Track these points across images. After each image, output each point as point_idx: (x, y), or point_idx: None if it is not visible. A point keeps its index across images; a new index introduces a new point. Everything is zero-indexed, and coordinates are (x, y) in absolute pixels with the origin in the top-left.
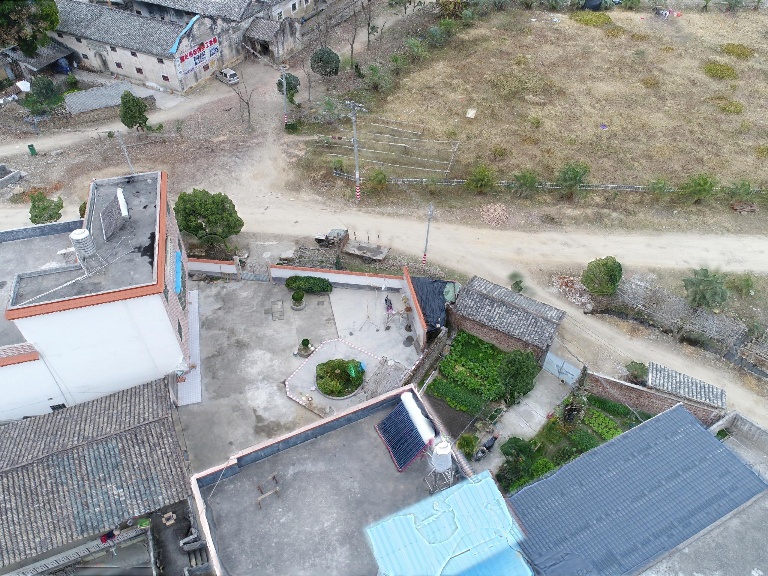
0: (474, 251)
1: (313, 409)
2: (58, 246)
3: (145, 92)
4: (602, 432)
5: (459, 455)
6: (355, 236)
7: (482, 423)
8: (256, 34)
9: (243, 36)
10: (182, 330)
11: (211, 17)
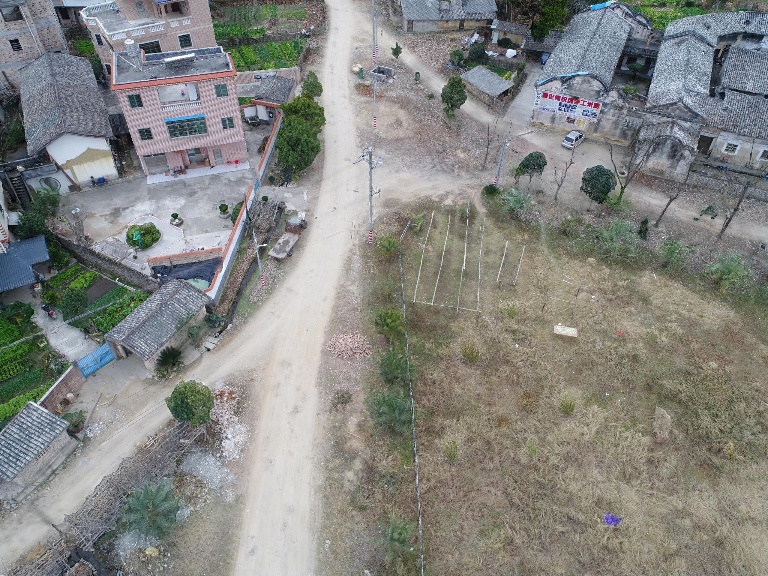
0: (287, 325)
1: (122, 229)
2: None
3: (529, 105)
4: (34, 390)
5: (31, 280)
6: (312, 242)
7: None
8: (647, 132)
9: None
10: (154, 138)
11: (604, 83)
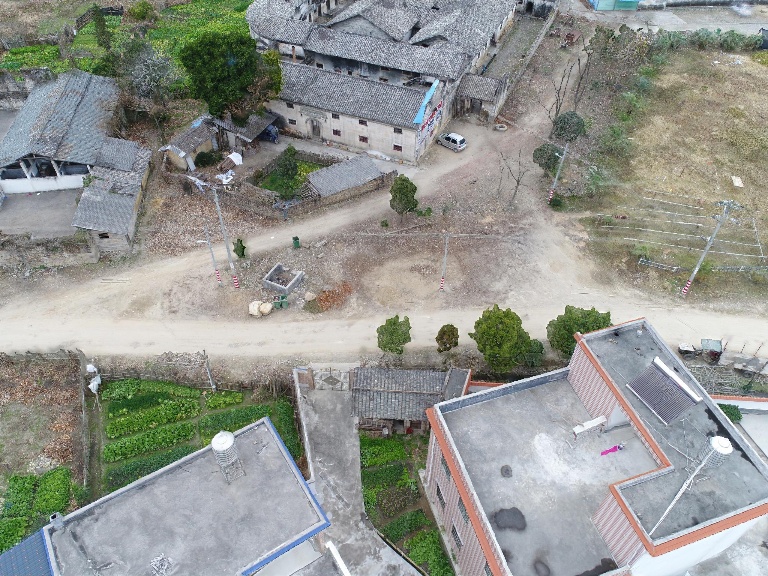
0: None
1: None
2: (529, 410)
3: None
4: None
5: None
6: None
7: None
8: (470, 92)
9: (455, 94)
10: None
11: (444, 80)
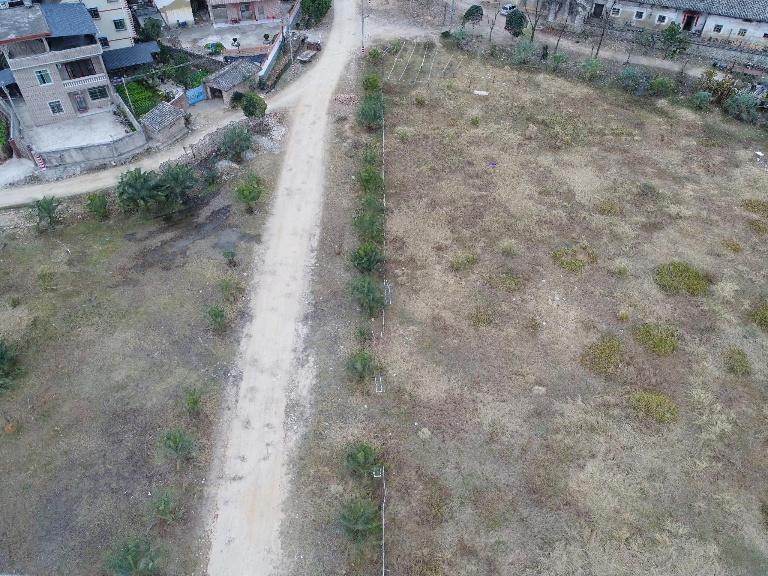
0: (308, 91)
1: None
2: None
3: None
4: None
5: (151, 60)
6: None
7: (177, 81)
8: None
9: None
10: None
11: None
